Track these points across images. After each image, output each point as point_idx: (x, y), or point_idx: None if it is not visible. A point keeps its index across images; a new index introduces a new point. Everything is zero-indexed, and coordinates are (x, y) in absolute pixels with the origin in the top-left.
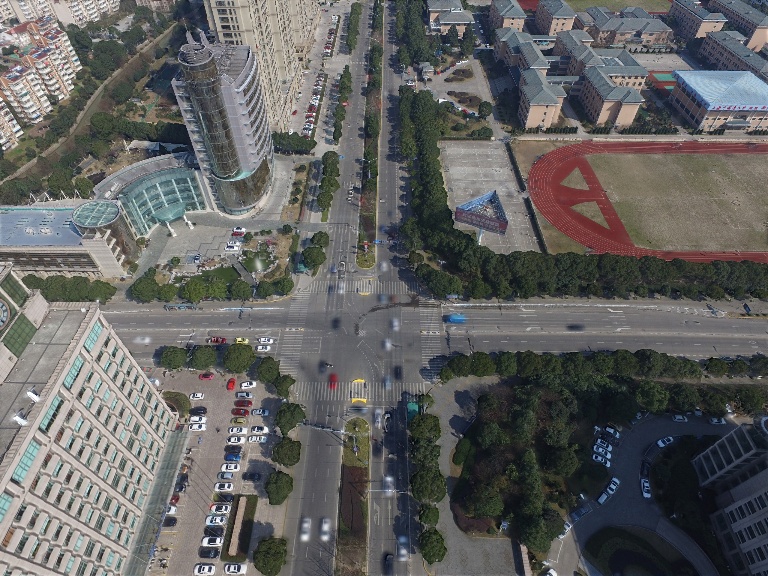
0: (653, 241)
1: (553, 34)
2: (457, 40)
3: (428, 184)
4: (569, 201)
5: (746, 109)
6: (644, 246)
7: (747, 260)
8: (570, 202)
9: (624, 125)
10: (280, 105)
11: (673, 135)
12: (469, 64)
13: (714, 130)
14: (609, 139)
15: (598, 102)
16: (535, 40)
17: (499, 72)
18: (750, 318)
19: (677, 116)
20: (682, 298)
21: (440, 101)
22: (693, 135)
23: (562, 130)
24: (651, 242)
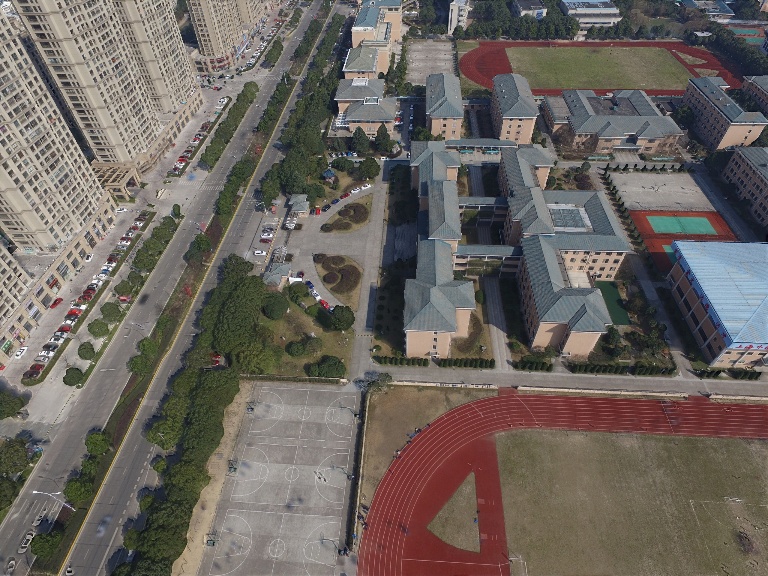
0: None
1: (506, 138)
2: (367, 146)
3: (132, 573)
4: None
5: None
6: None
7: None
8: None
9: (578, 354)
10: (1, 312)
11: (665, 377)
12: (370, 192)
13: (740, 373)
14: (547, 389)
15: (534, 312)
16: (479, 146)
17: (403, 217)
18: None
19: (677, 325)
20: None
21: (291, 281)
22: (702, 378)
23: (468, 363)
24: None
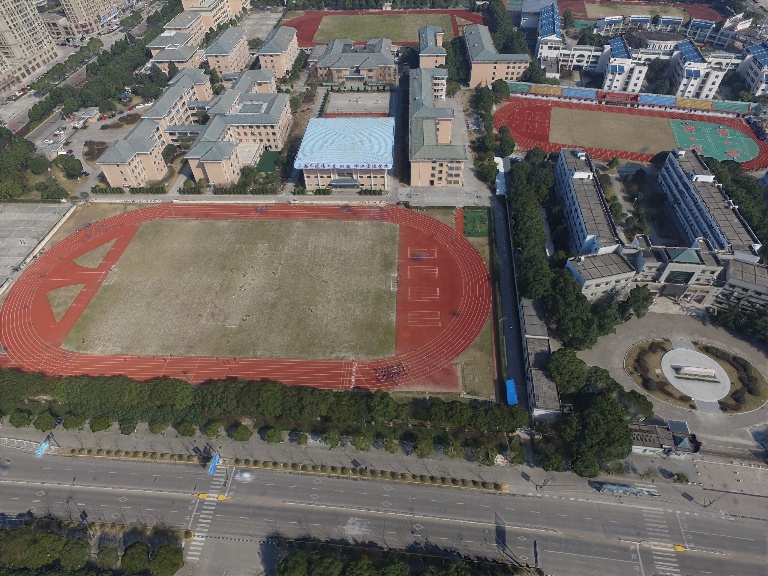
0: (88, 340)
1: None
2: (163, 79)
3: None
4: (55, 283)
5: (338, 167)
6: (70, 347)
7: (112, 378)
8: (55, 285)
9: (221, 184)
10: None
11: (272, 195)
12: None
13: (316, 190)
14: (191, 201)
15: None
16: None
17: None
18: (78, 456)
19: None
20: (28, 424)
21: (59, 154)
22: (295, 195)
23: (148, 190)
24: (84, 341)
